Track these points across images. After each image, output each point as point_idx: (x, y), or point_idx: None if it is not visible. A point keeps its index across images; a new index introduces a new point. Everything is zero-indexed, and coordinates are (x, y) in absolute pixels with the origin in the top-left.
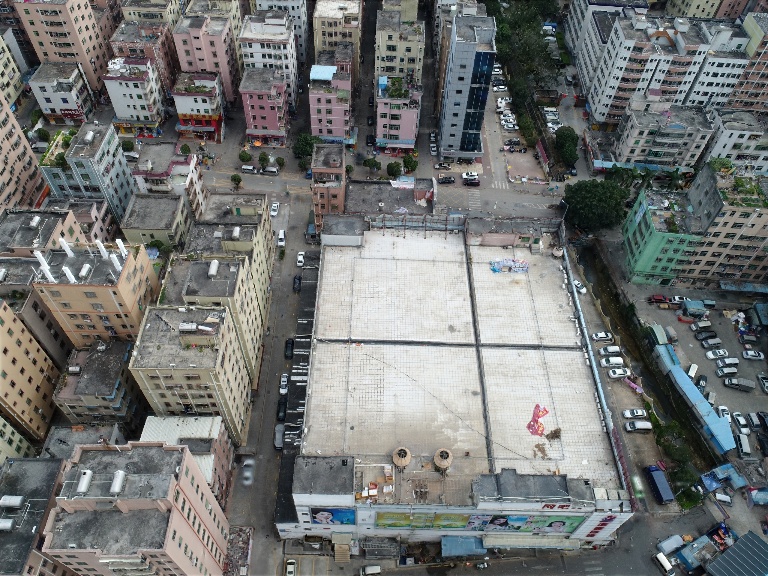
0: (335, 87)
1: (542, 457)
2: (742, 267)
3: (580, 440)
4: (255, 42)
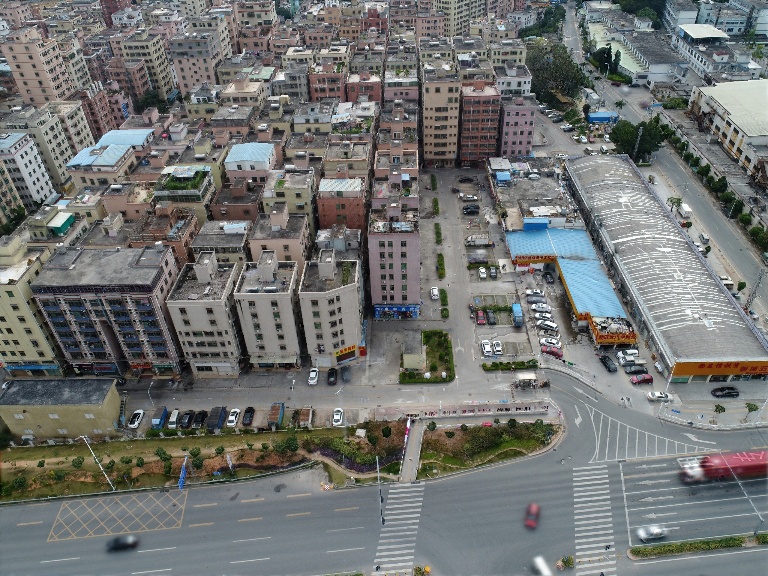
0: None
1: (381, 5)
2: (317, 1)
3: (377, 3)
4: None
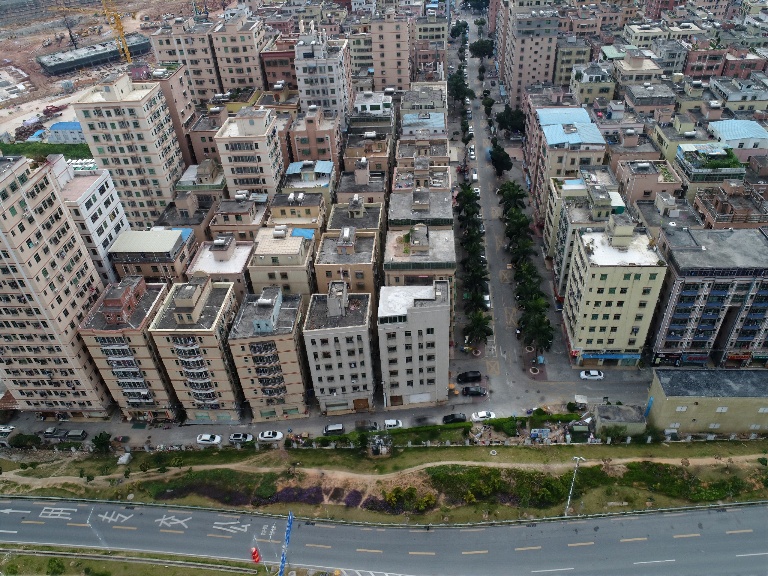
0: (438, 8)
1: None
2: None
3: None
4: (421, 5)
